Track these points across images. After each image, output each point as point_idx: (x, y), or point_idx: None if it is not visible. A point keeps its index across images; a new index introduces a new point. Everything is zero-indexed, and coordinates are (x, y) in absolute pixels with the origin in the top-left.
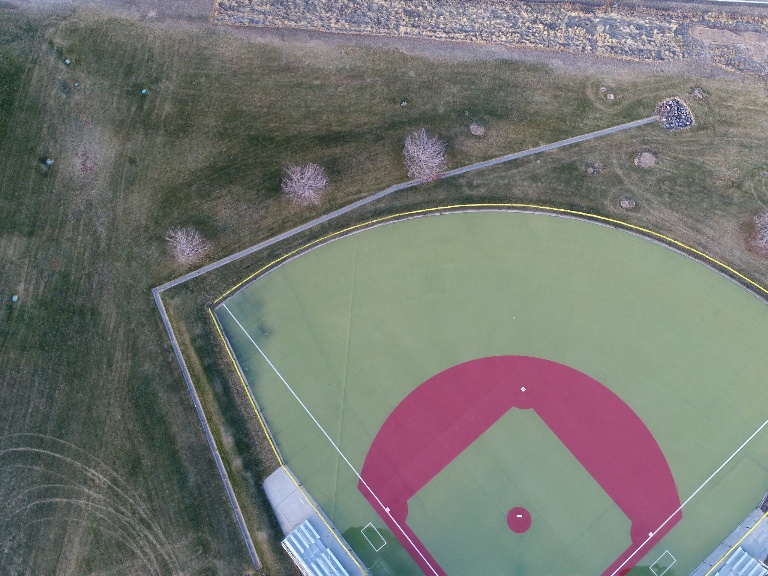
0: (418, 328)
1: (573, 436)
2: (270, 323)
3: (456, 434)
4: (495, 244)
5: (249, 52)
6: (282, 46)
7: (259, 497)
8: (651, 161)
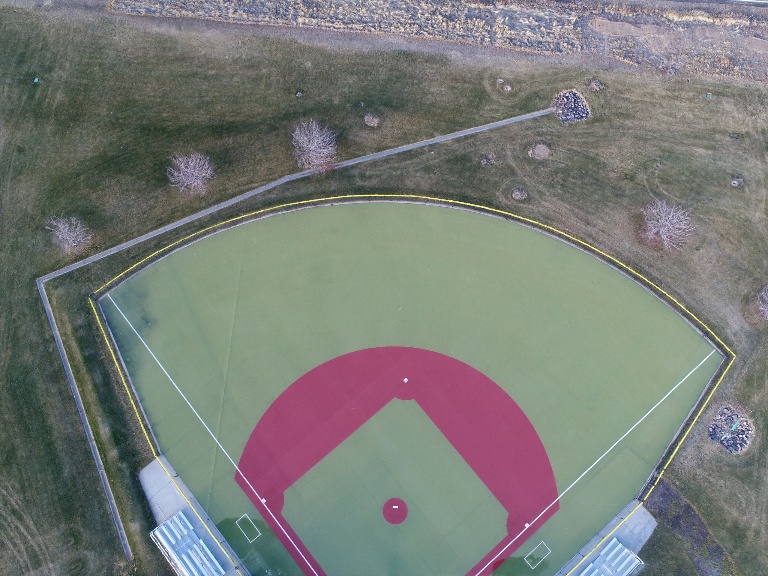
0: (303, 319)
1: (453, 427)
2: (154, 313)
3: (336, 425)
4: (385, 235)
5: (145, 41)
6: (178, 36)
7: (134, 488)
8: (545, 153)
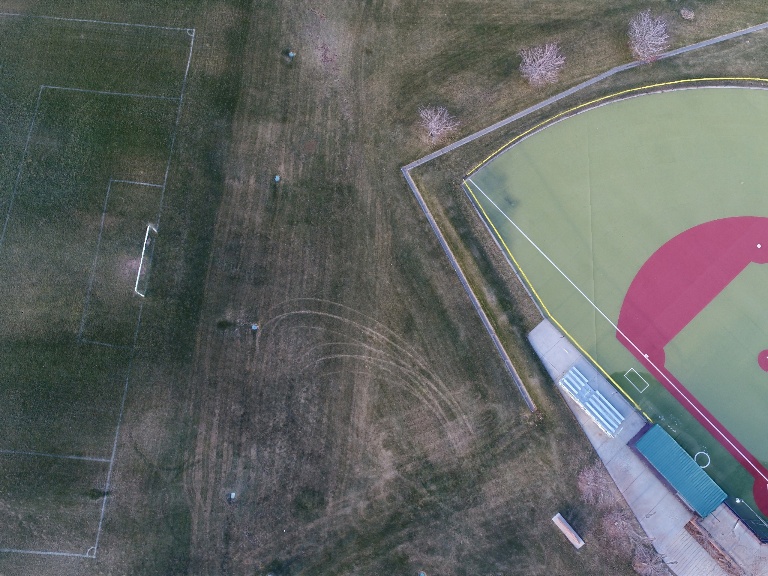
0: (654, 195)
1: None
2: (515, 195)
3: (701, 287)
4: (717, 117)
5: None
6: None
7: (527, 348)
8: None
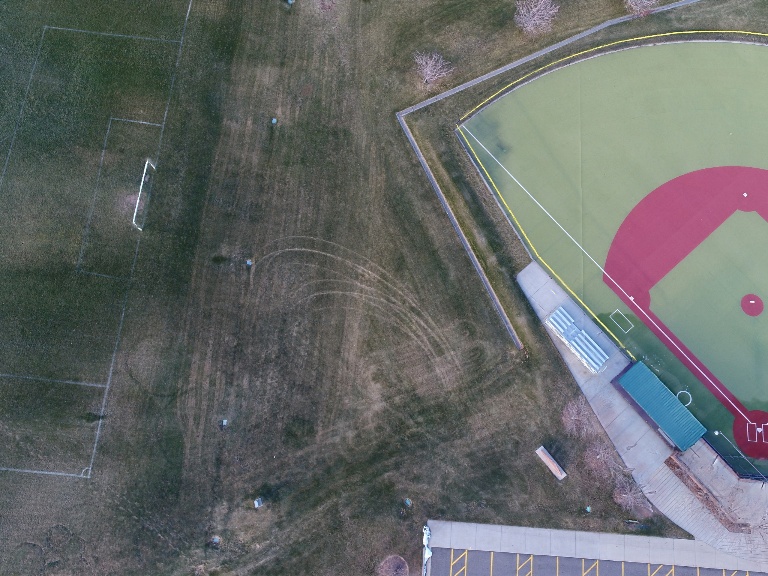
0: (644, 144)
1: None
2: (507, 141)
3: (688, 233)
4: (707, 70)
5: None
6: None
7: (515, 288)
8: None
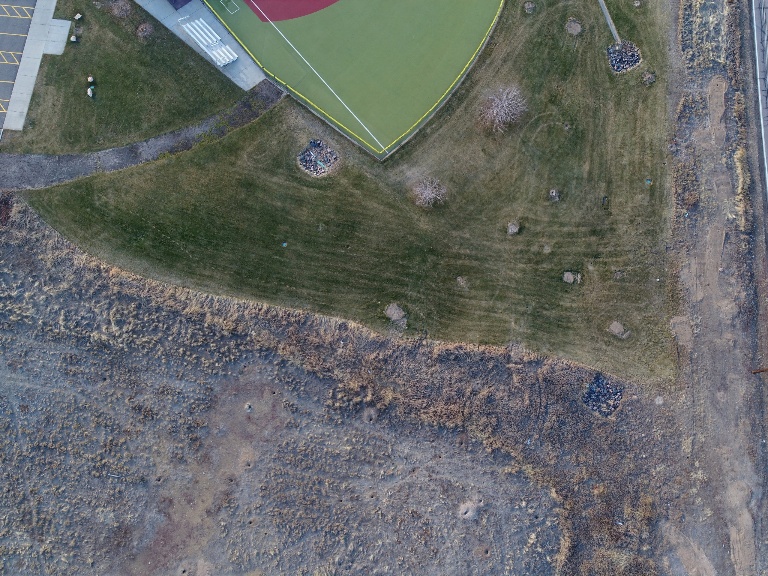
0: None
1: None
2: None
3: None
4: None
5: None
6: None
7: None
8: (573, 31)
